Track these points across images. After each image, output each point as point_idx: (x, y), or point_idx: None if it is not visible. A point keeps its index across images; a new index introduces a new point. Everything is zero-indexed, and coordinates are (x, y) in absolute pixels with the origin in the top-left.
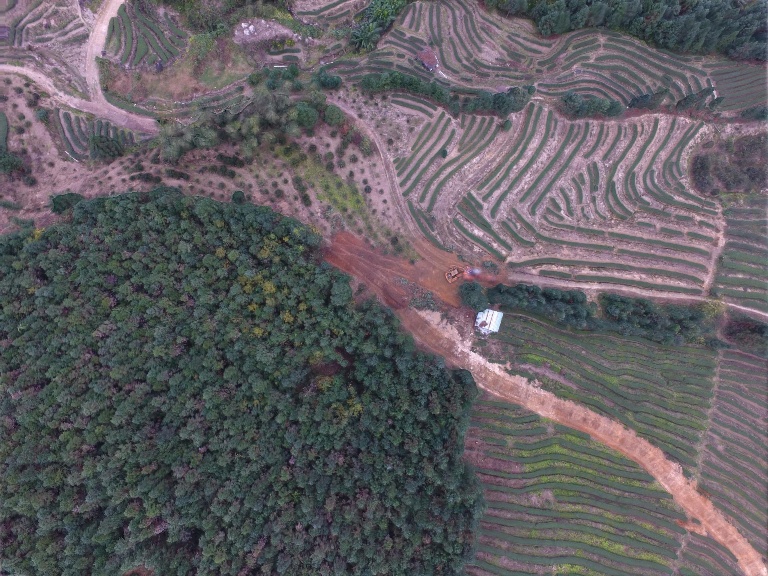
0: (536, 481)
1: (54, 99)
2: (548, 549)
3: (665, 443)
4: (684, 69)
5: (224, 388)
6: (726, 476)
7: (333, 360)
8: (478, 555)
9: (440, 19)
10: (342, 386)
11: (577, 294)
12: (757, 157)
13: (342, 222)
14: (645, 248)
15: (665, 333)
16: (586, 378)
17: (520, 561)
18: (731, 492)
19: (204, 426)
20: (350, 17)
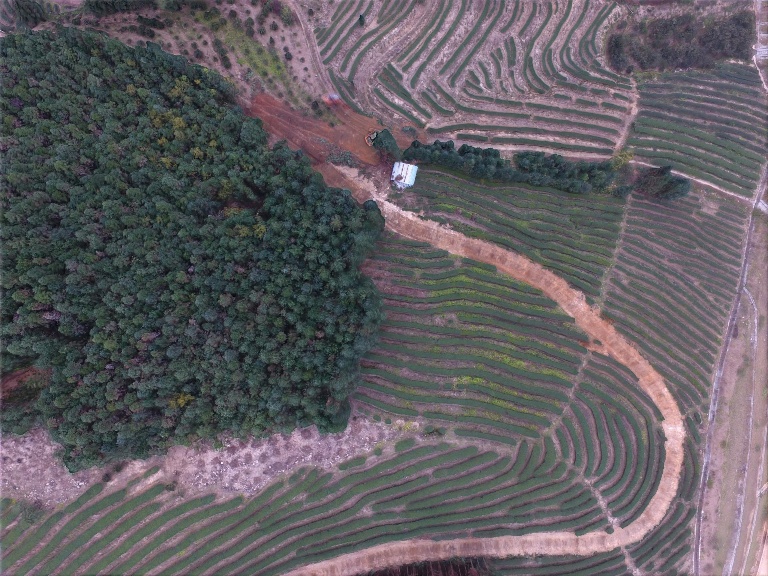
0: (441, 305)
1: None
2: (449, 363)
3: (570, 275)
4: None
5: (128, 206)
6: (630, 307)
7: (243, 194)
8: (379, 367)
9: None
10: (250, 215)
11: (489, 148)
12: (670, 39)
13: (262, 85)
14: (560, 115)
15: (573, 180)
16: (497, 223)
17: (421, 373)
18: (634, 321)
19: (104, 235)
20: None
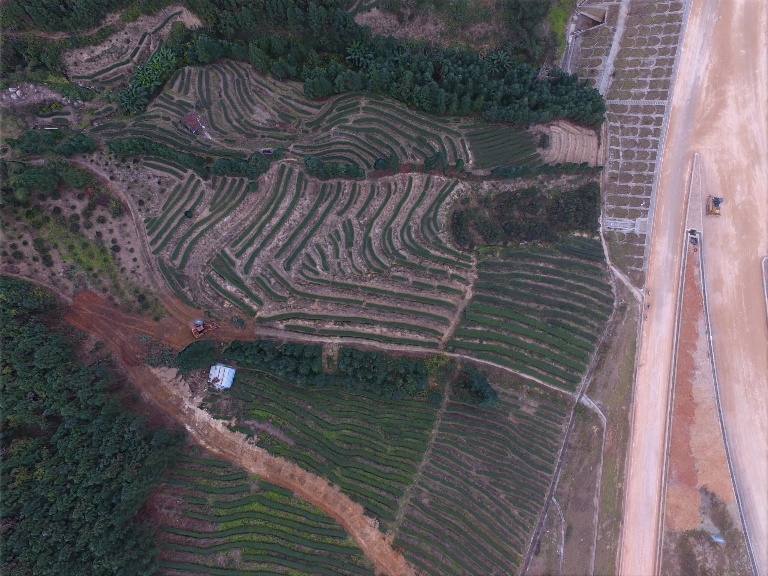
0: (226, 540)
1: None
2: None
3: (368, 498)
4: (441, 130)
5: None
6: (427, 529)
7: None
8: None
9: (209, 83)
10: (37, 449)
11: (307, 350)
12: (516, 212)
13: (85, 281)
14: (392, 302)
15: (385, 388)
16: (306, 433)
17: None
18: (429, 545)
19: None
20: (126, 80)
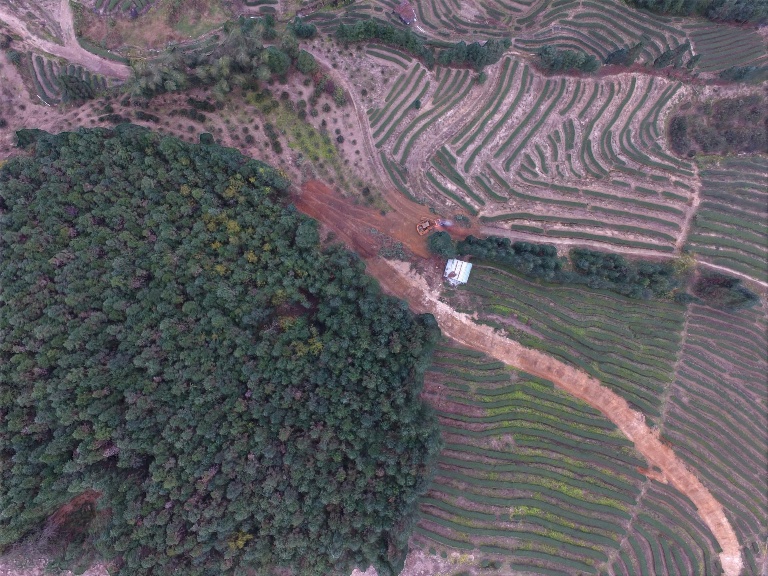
0: (497, 425)
1: (27, 43)
2: (506, 491)
3: (629, 393)
4: (663, 29)
5: (183, 322)
6: (690, 427)
7: (296, 301)
8: (435, 495)
9: None
10: (304, 326)
11: (547, 246)
12: (735, 120)
13: (313, 171)
14: (619, 206)
15: (634, 286)
16: (553, 329)
17: (477, 502)
18: (694, 443)
19: (160, 357)
20: None
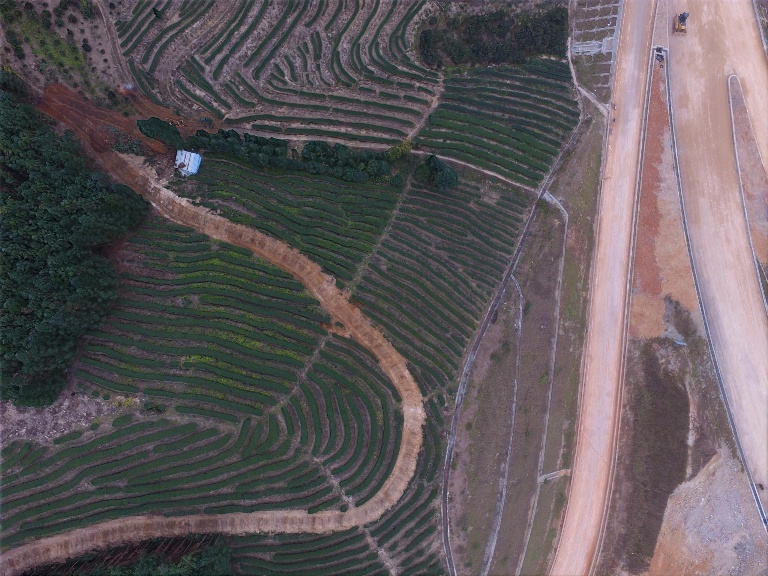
0: (185, 287)
1: None
2: (181, 342)
3: (326, 260)
4: None
5: None
6: (384, 291)
7: (1, 178)
8: (107, 345)
9: None
10: (2, 198)
11: None
12: (484, 35)
13: (56, 75)
14: (359, 107)
15: None
16: (268, 209)
17: (150, 351)
18: (386, 305)
19: None
20: None
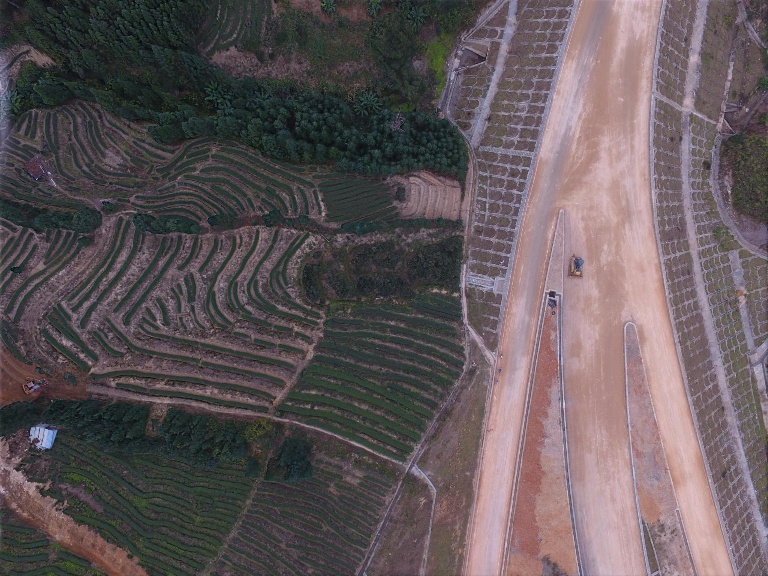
0: None
1: None
2: None
3: (166, 571)
4: (294, 180)
5: None
6: None
7: None
8: None
9: (58, 126)
10: None
11: (126, 414)
12: (373, 265)
13: None
14: (229, 361)
15: (199, 457)
16: (117, 500)
17: None
18: None
19: None
20: None
